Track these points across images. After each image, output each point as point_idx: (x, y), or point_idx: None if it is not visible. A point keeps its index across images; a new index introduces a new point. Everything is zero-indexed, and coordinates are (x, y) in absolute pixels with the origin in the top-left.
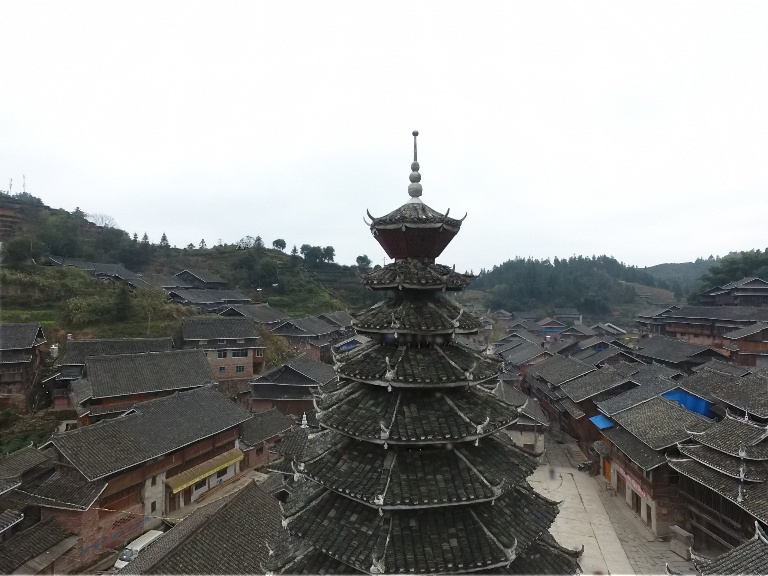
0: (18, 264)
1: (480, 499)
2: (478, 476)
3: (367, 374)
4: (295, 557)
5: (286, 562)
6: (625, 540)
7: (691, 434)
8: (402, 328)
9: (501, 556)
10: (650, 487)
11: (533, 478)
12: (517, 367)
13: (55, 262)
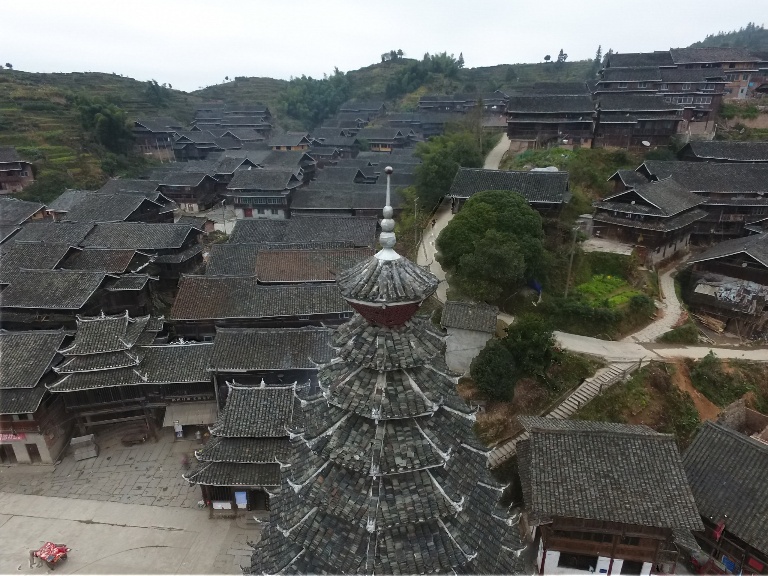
0: None
1: None
2: None
3: (465, 433)
4: None
5: None
6: (37, 490)
7: (66, 352)
8: None
9: None
10: (34, 425)
11: None
12: None
13: None
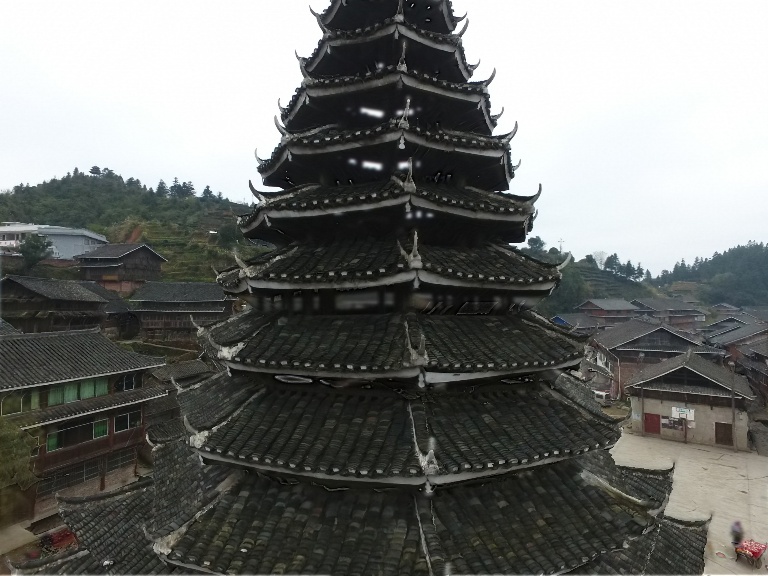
0: (227, 244)
1: (387, 200)
2: (398, 184)
3: None
4: (228, 317)
5: (218, 321)
6: None
7: None
8: (333, 37)
9: (399, 262)
10: None
11: (726, 462)
12: (726, 349)
13: (252, 243)
